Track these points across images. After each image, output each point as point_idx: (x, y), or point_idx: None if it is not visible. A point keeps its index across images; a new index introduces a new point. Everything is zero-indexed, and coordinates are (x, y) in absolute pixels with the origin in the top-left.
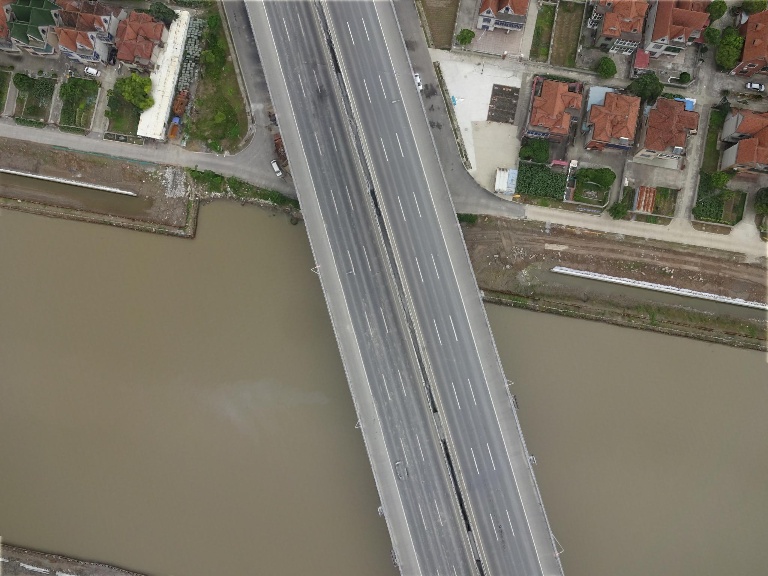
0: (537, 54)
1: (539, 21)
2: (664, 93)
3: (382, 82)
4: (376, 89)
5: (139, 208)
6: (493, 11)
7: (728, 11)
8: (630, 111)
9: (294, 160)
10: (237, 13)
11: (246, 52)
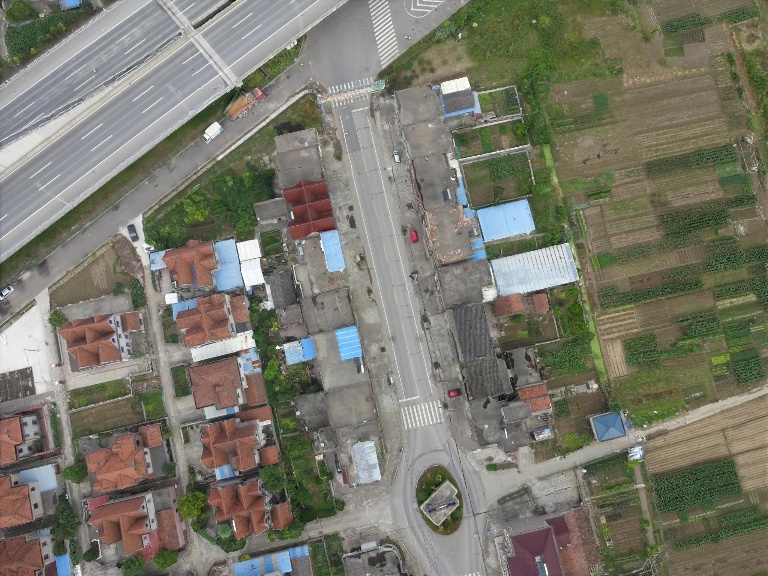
0: (76, 396)
1: (112, 384)
2: (77, 541)
3: None
4: None
5: None
6: (65, 336)
7: (191, 570)
8: (8, 516)
9: None
10: None
11: None
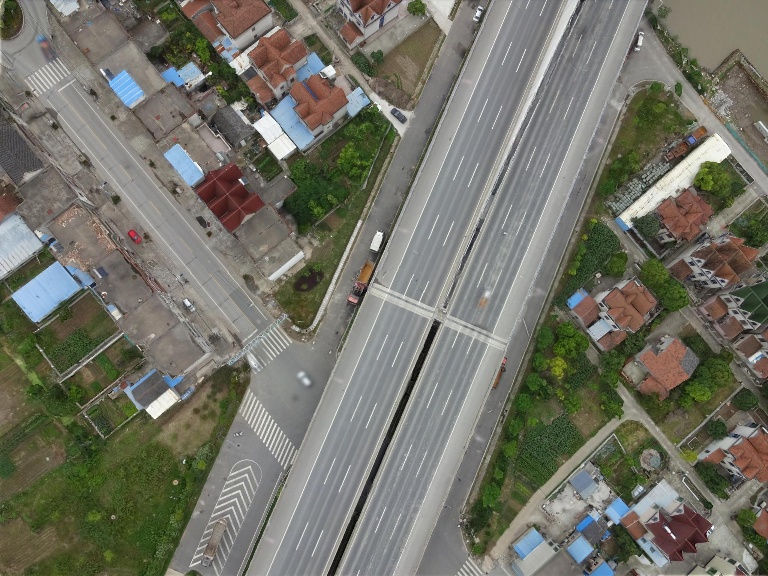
0: None
1: None
2: None
3: (528, 2)
4: (537, 0)
5: (759, 113)
6: None
7: None
8: None
9: (642, 1)
10: (575, 194)
11: (592, 155)
